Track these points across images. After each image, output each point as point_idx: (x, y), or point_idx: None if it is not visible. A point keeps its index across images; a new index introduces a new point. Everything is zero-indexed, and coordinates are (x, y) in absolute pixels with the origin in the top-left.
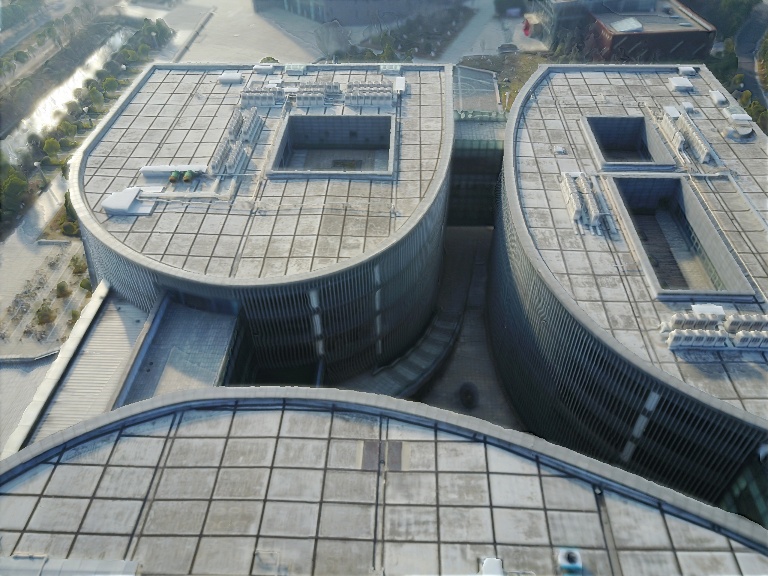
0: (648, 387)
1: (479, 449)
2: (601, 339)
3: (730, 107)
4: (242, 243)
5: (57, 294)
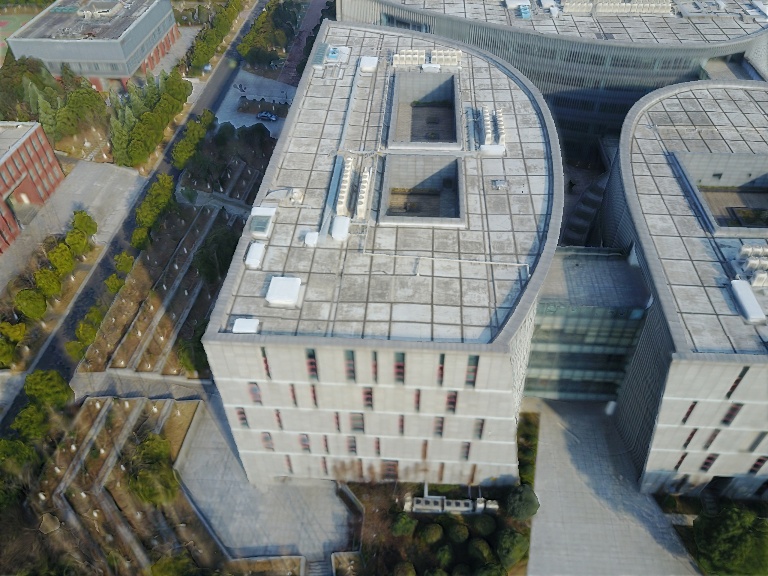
0: None
1: None
2: None
3: (259, 231)
4: (761, 110)
5: None
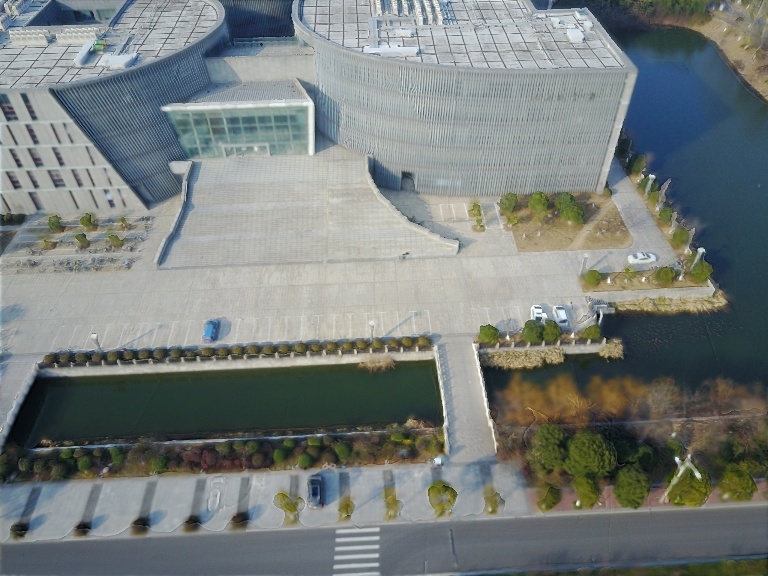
0: None
1: None
2: None
3: None
4: None
5: (84, 248)
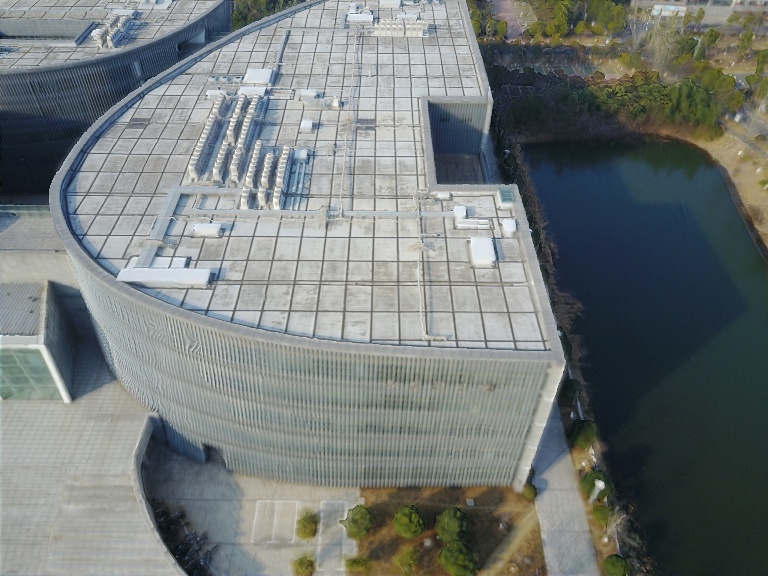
0: (132, 61)
1: (149, 97)
2: (98, 59)
3: None
4: None
5: None
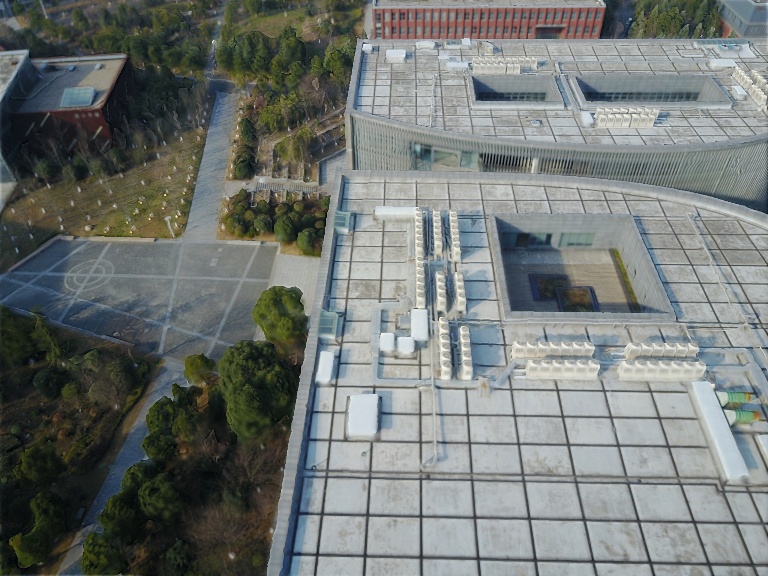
0: None
1: None
2: None
3: (446, 43)
4: None
5: None
